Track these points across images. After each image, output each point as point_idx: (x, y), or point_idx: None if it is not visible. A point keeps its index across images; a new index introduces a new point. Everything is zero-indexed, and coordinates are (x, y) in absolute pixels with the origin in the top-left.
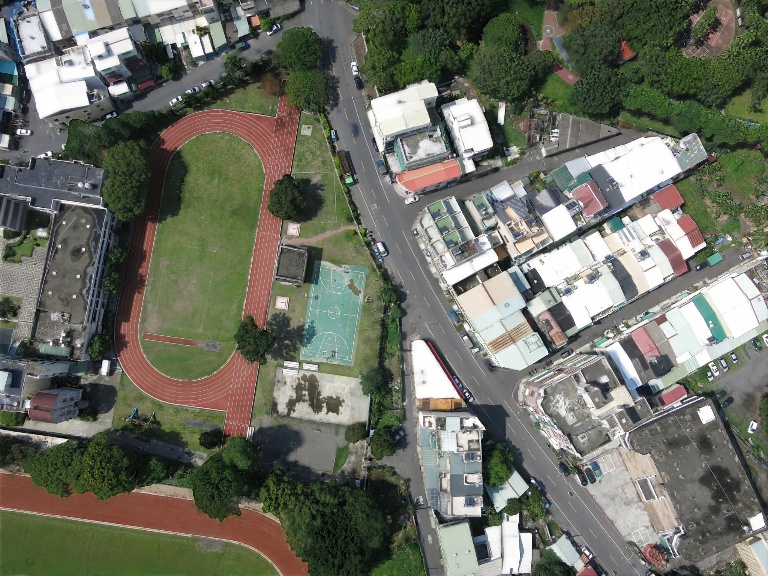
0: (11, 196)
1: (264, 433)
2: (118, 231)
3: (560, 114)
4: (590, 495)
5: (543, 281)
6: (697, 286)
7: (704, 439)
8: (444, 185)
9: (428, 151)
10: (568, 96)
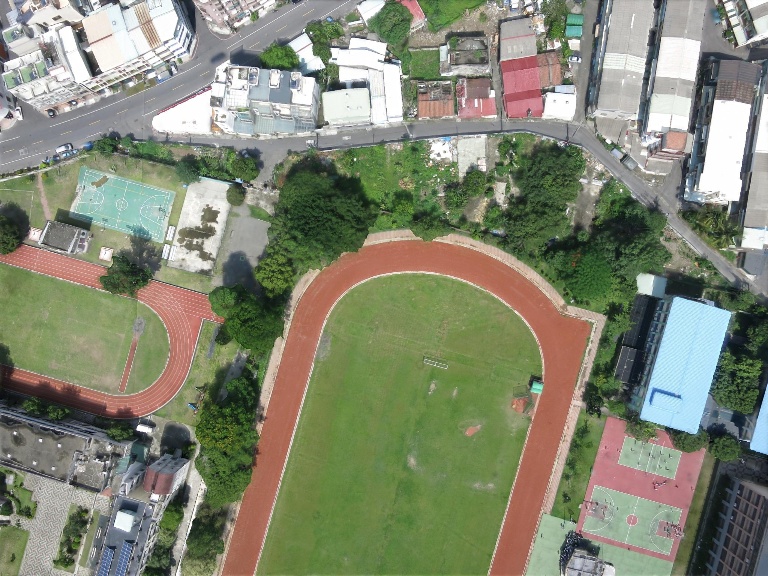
0: None
1: (228, 285)
2: (9, 402)
3: None
4: None
5: None
6: None
7: None
8: None
9: None
10: None
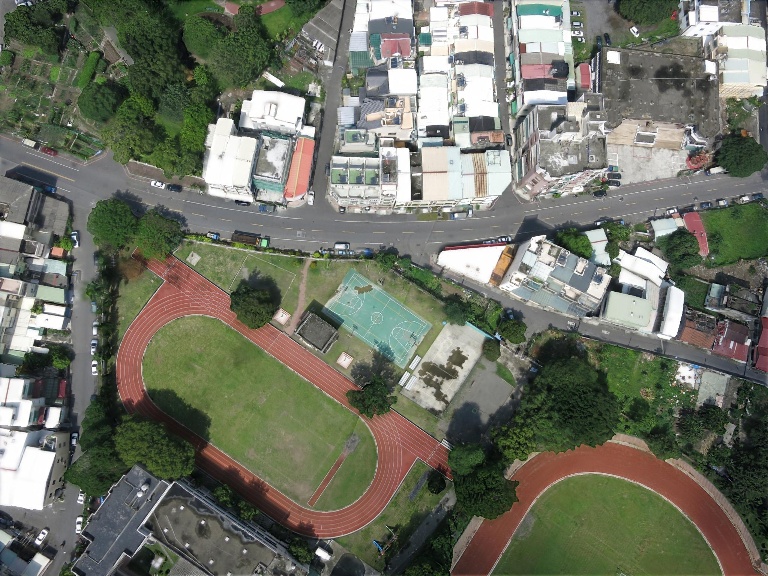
0: (109, 574)
1: (452, 432)
2: (199, 482)
3: (302, 31)
4: (629, 185)
5: (441, 125)
6: (505, 8)
7: (631, 70)
8: (312, 163)
9: (279, 157)
10: (289, 16)
